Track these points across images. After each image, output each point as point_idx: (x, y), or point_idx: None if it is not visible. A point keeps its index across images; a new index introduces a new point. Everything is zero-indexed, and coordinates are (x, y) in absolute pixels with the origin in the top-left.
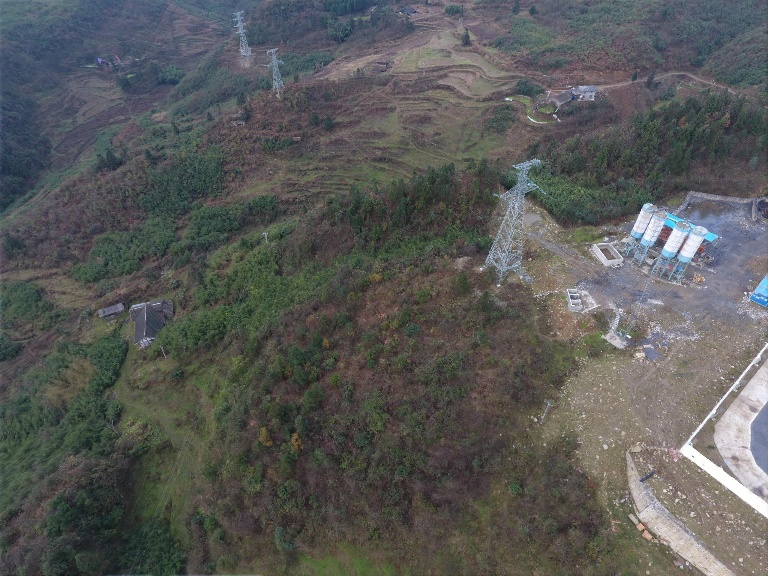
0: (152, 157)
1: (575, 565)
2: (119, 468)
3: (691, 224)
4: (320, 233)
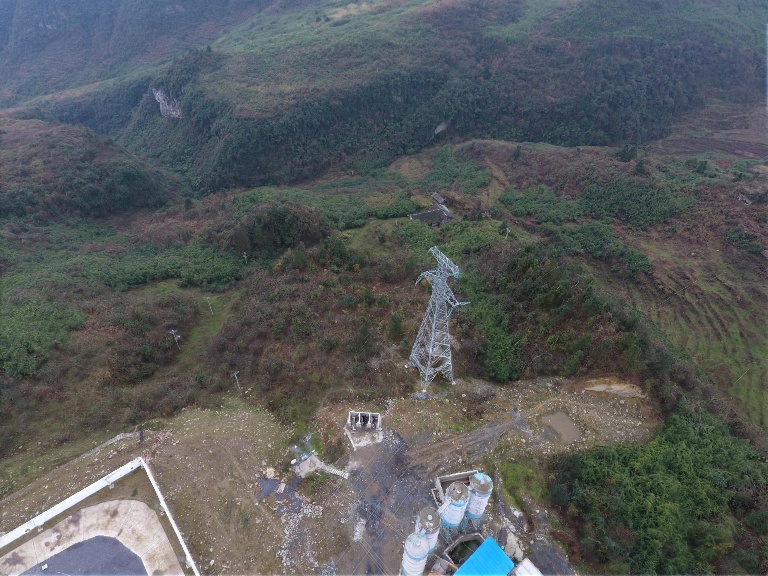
0: (640, 168)
1: None
2: (310, 230)
3: None
4: (497, 249)
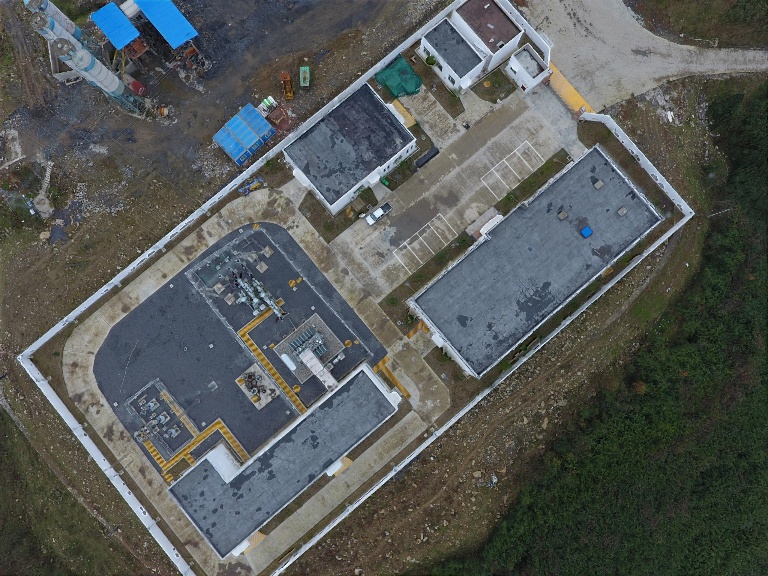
0: None
1: None
2: None
3: (171, 5)
4: None
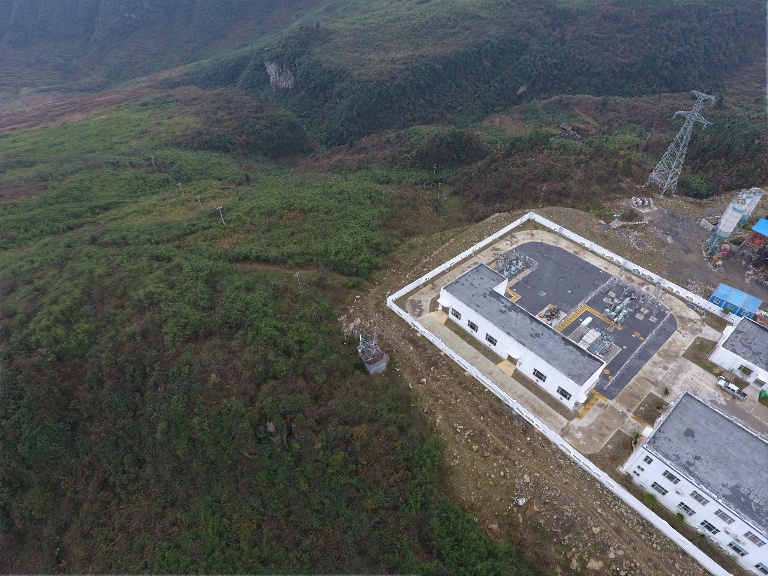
0: (720, 104)
1: (467, 223)
2: (481, 147)
3: None
4: (657, 139)
